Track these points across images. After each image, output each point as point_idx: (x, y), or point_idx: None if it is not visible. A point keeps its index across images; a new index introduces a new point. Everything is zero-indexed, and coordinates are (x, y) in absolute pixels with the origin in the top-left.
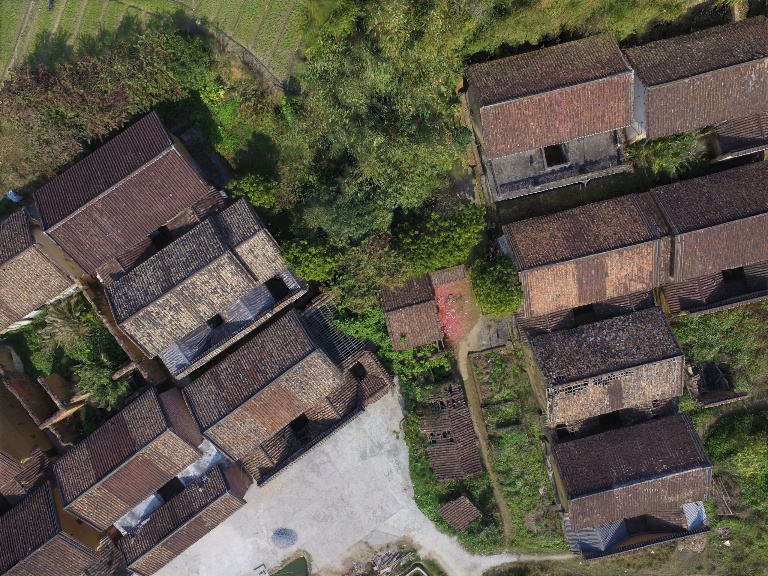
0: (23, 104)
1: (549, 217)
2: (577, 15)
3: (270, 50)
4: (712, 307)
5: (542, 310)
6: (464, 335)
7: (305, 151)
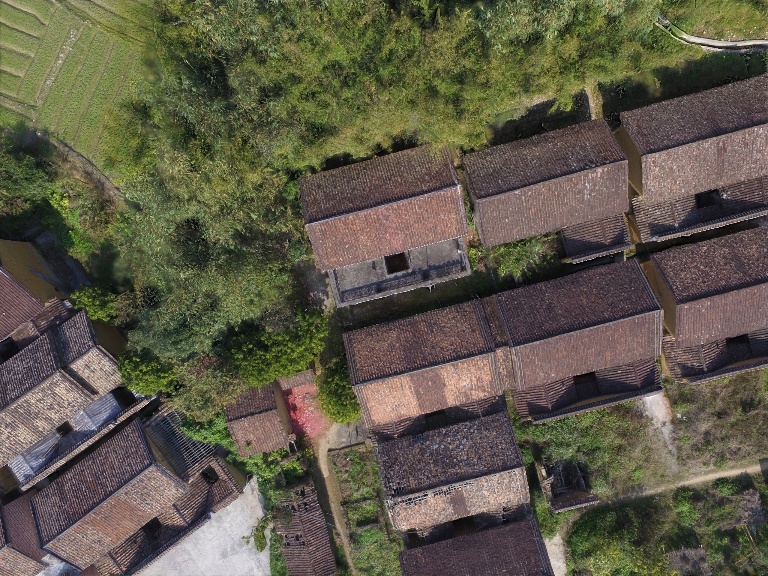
0: None
1: (390, 324)
2: (399, 130)
3: (110, 159)
4: (556, 415)
5: (383, 419)
6: (324, 432)
7: None
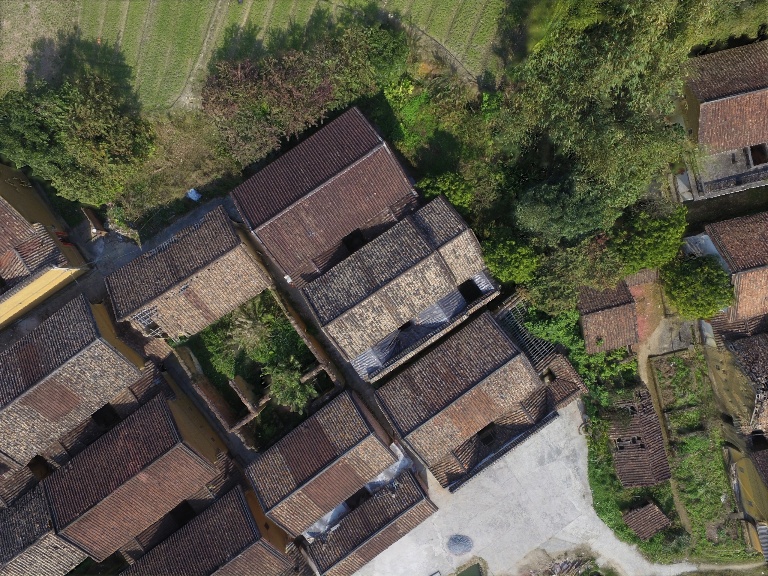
0: (230, 100)
1: (754, 217)
2: None
3: (464, 44)
4: None
5: (748, 313)
6: (645, 338)
7: (487, 148)
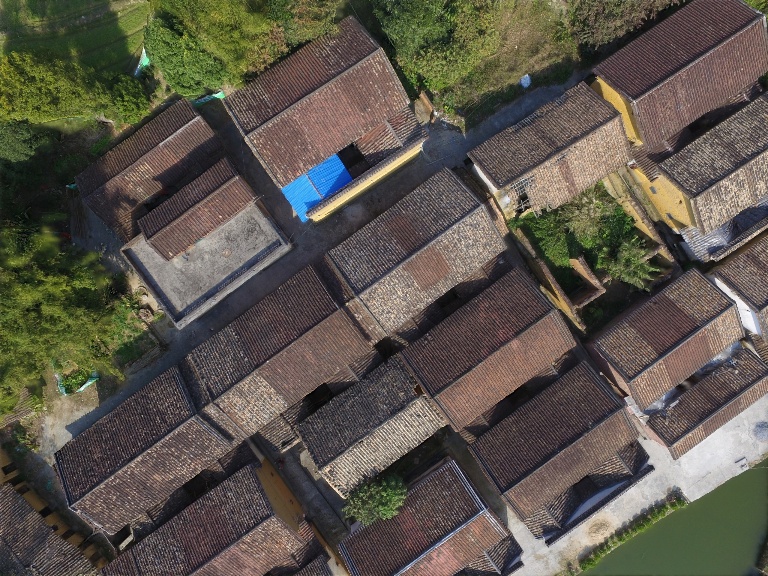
0: None
1: None
2: None
3: None
4: None
5: None
6: None
7: None
